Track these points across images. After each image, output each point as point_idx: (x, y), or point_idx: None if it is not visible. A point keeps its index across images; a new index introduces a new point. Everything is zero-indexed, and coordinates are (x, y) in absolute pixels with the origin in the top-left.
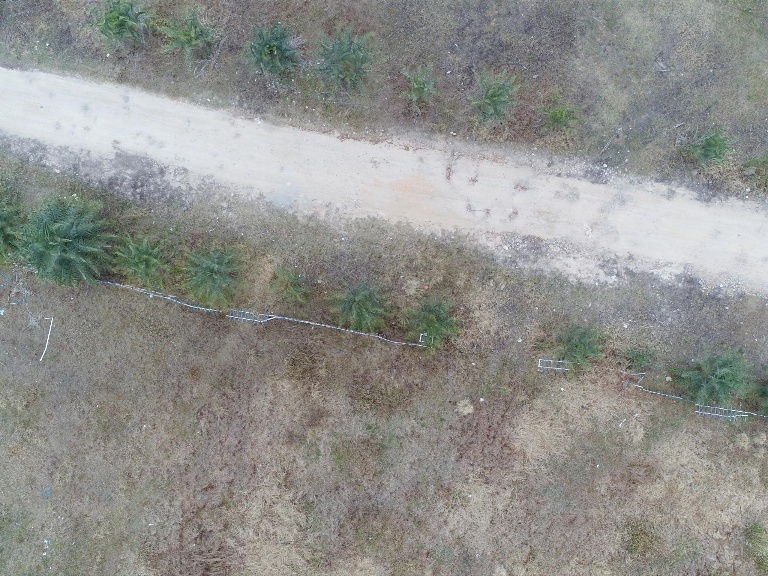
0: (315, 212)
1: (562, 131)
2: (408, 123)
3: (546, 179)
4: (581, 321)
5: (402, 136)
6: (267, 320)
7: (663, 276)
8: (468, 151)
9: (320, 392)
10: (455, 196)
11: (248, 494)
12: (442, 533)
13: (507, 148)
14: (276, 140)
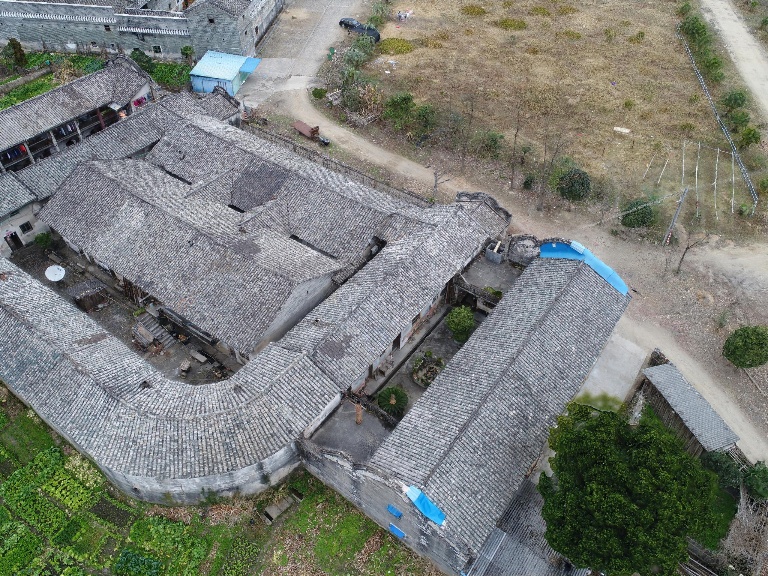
0: None
1: (750, 13)
2: None
3: None
4: (691, 17)
5: None
6: None
7: (716, 27)
8: None
9: None
10: (715, 1)
11: None
12: None
13: (736, 7)
14: None
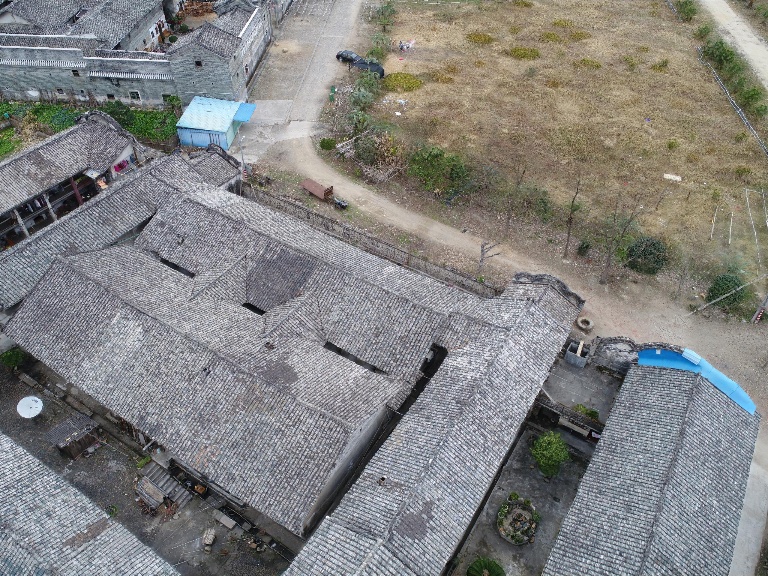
0: (704, 5)
1: None
2: (745, 15)
3: (751, 33)
4: (710, 40)
5: (740, 15)
6: (665, 1)
7: (739, 51)
8: (747, 23)
9: (650, 7)
10: None
11: (611, 0)
12: (620, 23)
13: None
14: (720, 0)
